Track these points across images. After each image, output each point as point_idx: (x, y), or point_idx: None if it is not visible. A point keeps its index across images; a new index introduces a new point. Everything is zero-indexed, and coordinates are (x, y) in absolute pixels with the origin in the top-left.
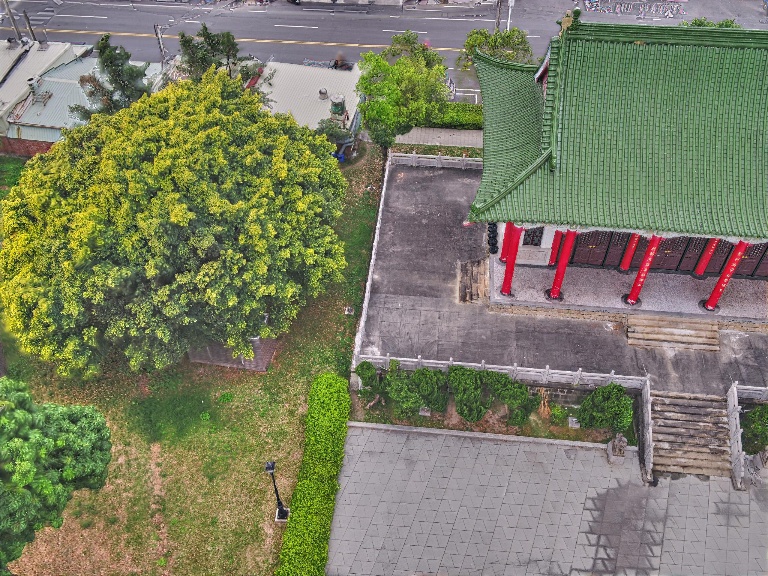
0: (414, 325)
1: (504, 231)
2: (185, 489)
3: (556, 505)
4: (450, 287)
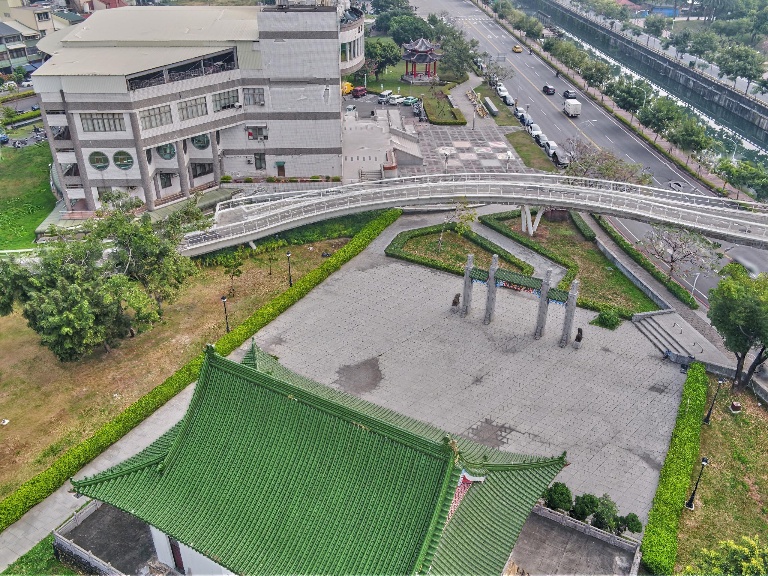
0: (581, 572)
1: None
2: (763, 543)
3: None
4: None
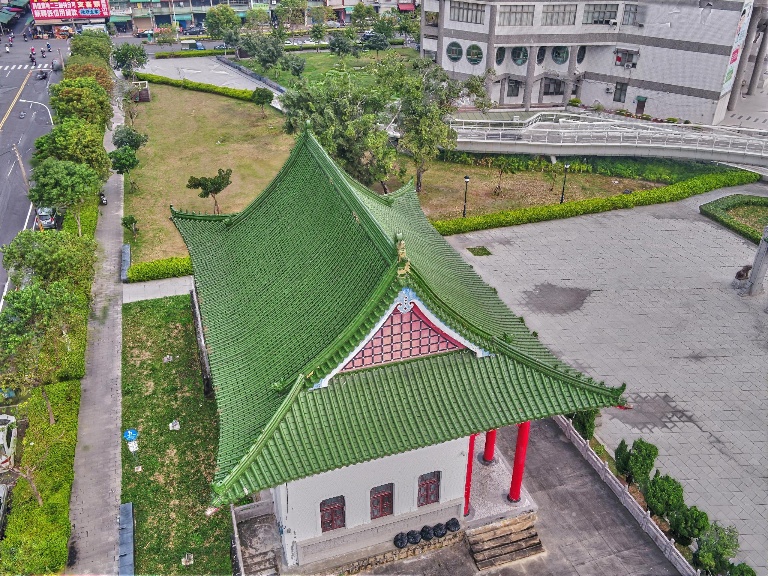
0: None
1: (461, 488)
2: None
3: (667, 448)
4: (527, 569)
